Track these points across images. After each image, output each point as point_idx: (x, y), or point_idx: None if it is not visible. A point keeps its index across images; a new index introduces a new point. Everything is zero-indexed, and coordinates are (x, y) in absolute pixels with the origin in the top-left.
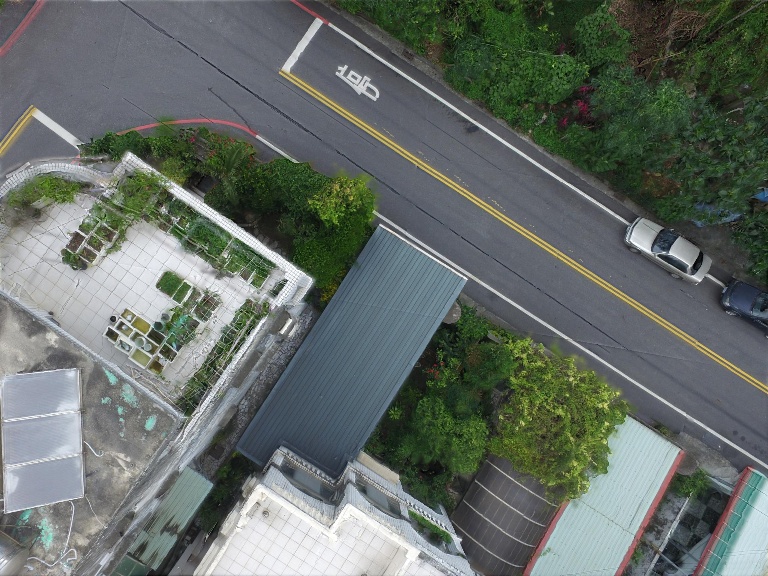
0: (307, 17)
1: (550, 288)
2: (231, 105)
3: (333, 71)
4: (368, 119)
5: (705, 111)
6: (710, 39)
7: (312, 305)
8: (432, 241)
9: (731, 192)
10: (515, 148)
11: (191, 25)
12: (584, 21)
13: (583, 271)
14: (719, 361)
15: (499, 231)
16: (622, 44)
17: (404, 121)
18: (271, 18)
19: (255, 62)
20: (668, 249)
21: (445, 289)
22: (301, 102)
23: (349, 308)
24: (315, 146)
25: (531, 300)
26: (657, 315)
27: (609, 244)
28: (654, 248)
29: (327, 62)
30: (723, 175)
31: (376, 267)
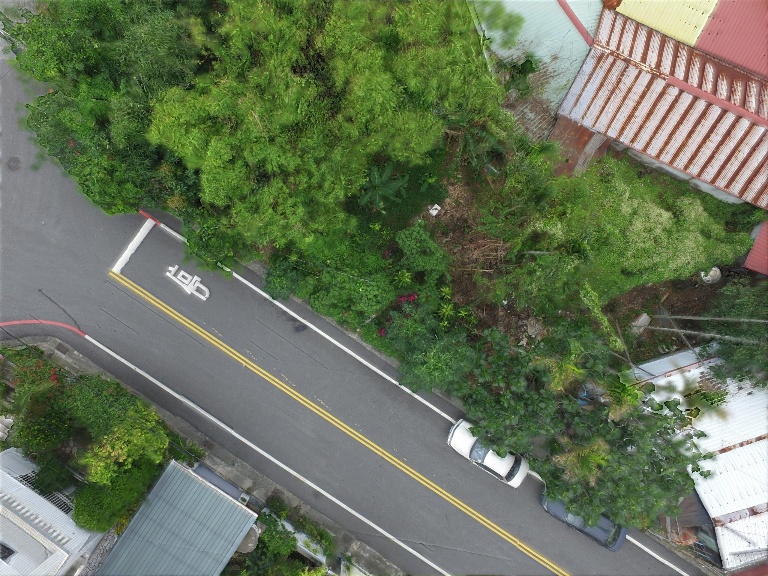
0: (140, 218)
1: (374, 487)
2: (61, 305)
3: (164, 271)
4: (197, 318)
5: (502, 343)
6: (513, 266)
7: (116, 526)
8: (258, 440)
9: (501, 450)
10: (343, 346)
11: (23, 227)
12: (401, 235)
13: (407, 470)
14: (540, 561)
15: (325, 430)
16: (437, 258)
17: (233, 320)
18: (104, 219)
19: (86, 263)
20: (483, 457)
21: (234, 527)
22: (131, 302)
23: (139, 545)
24: (144, 345)
25: (355, 499)
26: (479, 515)
27: (434, 442)
28: (472, 453)
29: (158, 262)
30: (497, 429)
31: (168, 503)
